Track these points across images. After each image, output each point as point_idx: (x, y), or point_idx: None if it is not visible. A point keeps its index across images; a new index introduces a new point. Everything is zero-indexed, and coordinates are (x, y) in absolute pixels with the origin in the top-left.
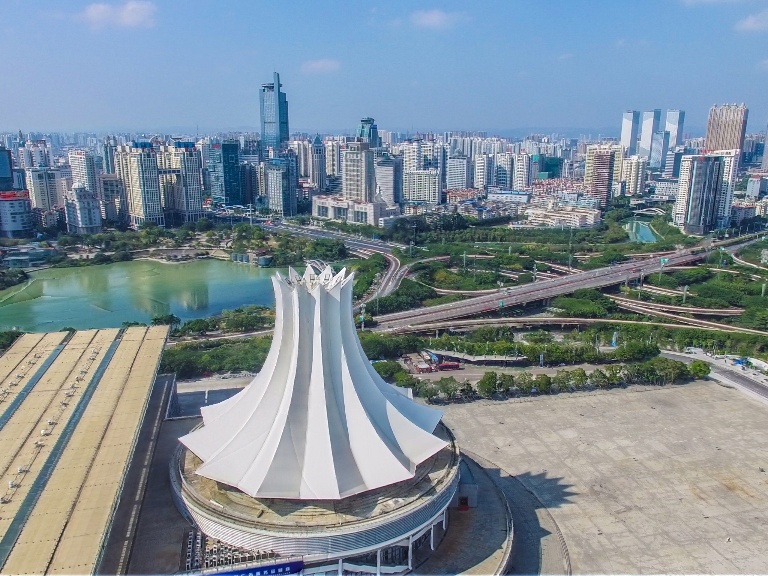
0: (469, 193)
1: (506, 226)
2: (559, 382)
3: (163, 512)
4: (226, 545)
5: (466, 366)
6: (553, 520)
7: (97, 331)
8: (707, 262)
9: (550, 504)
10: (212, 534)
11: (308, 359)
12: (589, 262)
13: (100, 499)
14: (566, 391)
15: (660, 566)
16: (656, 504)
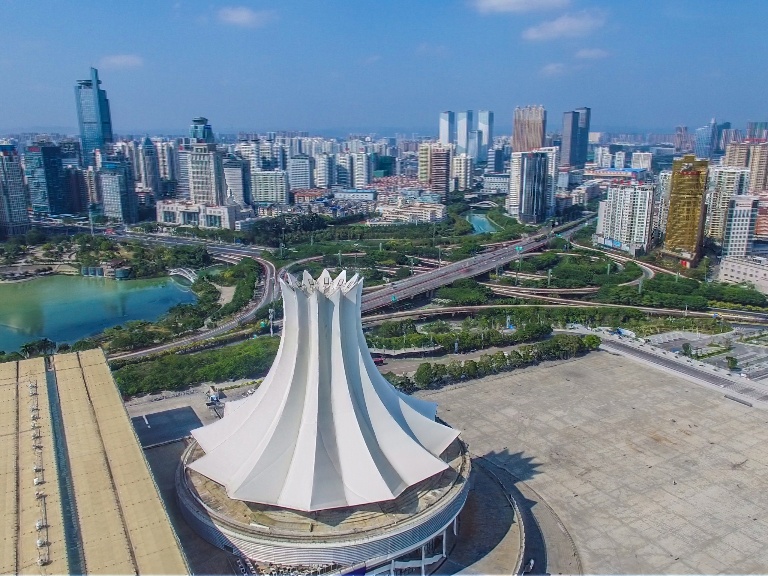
0: (317, 193)
1: (364, 224)
2: (484, 366)
3: (191, 546)
4: (283, 566)
5: (388, 361)
6: (533, 491)
7: (16, 363)
8: (549, 248)
9: (524, 477)
10: (261, 558)
11: (327, 365)
12: (452, 254)
13: (158, 541)
14: (490, 374)
15: (635, 514)
16: (608, 462)
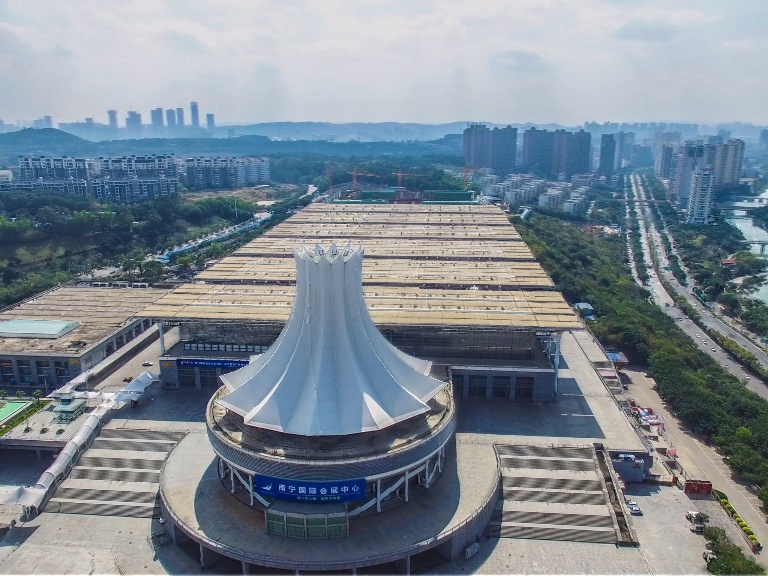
0: None
1: None
2: None
3: None
4: None
5: None
6: None
7: (566, 308)
8: None
9: None
10: None
11: None
12: None
13: None
14: None
15: None
16: None
